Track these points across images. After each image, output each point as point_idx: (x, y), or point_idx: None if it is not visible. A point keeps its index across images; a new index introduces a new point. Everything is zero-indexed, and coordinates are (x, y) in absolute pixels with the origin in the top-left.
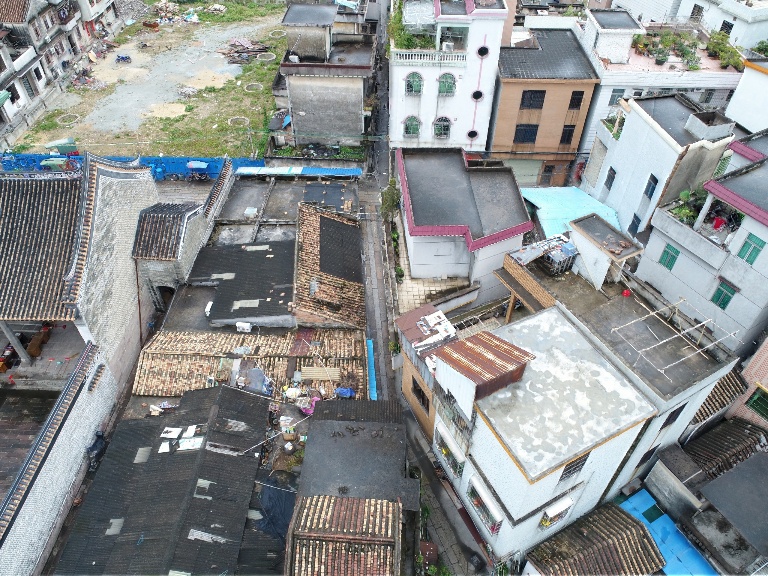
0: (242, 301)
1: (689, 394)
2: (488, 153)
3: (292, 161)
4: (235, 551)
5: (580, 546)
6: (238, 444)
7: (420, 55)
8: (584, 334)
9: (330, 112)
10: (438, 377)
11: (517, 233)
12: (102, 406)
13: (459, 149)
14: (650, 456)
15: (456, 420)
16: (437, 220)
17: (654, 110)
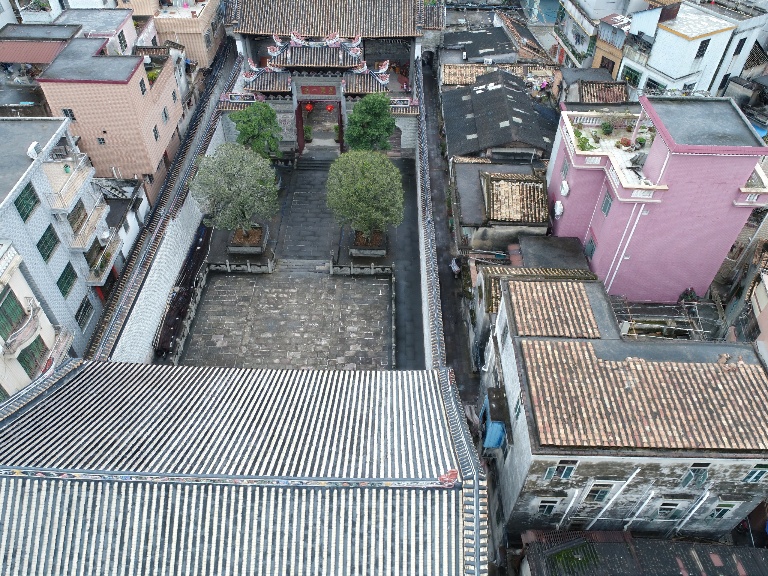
0: (484, 50)
1: (749, 26)
2: None
3: None
4: (535, 117)
5: None
6: None
7: None
8: (698, 9)
9: None
10: (632, 29)
11: None
12: None
13: None
14: (725, 85)
15: (642, 47)
16: None
17: None
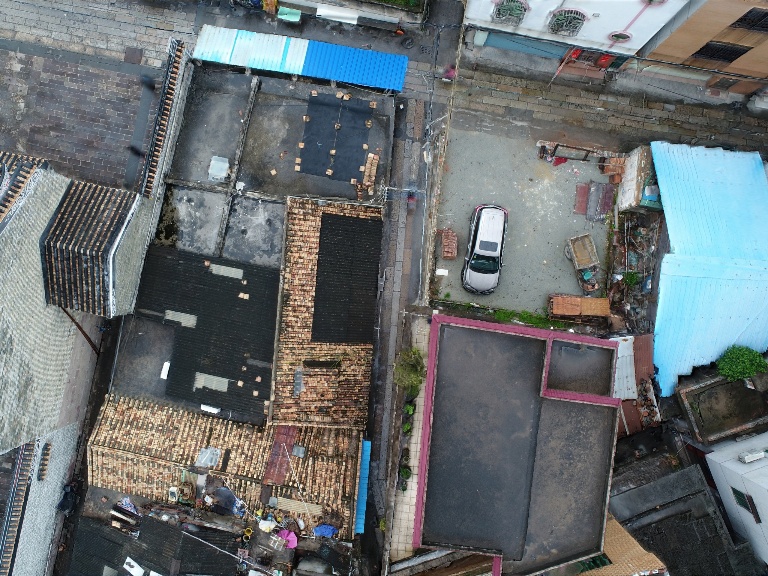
0: (206, 376)
1: None
2: (638, 59)
3: None
4: None
5: None
6: None
7: None
8: None
9: None
10: None
11: None
12: (63, 459)
13: (543, 339)
14: None
15: None
16: (461, 517)
17: None
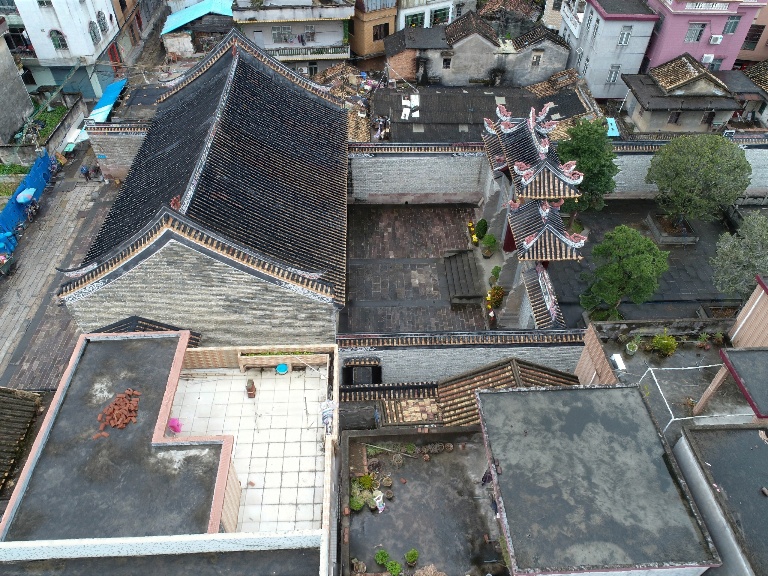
0: None
1: None
2: (121, 30)
3: (57, 134)
4: None
5: None
6: (411, 90)
7: None
8: None
9: (4, 90)
10: None
11: None
12: None
13: None
14: None
15: None
16: None
17: None
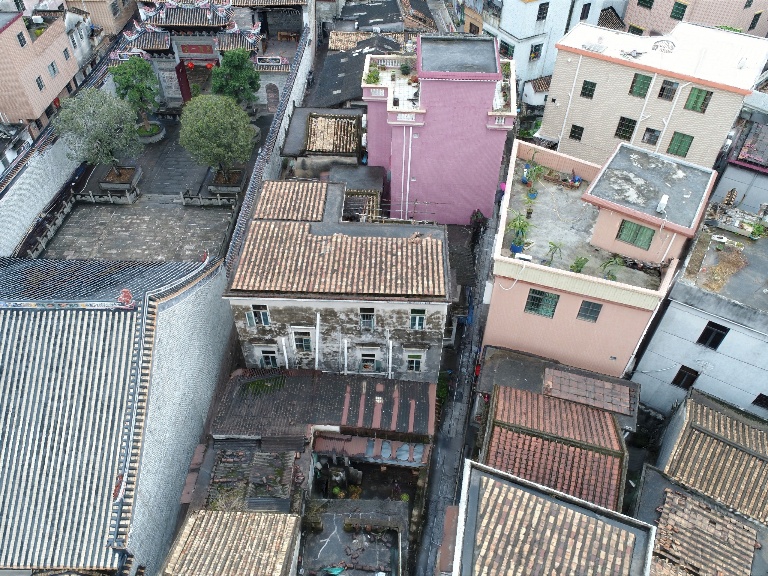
0: (374, 20)
1: None
2: None
3: None
4: None
5: None
6: None
7: None
8: None
9: None
10: None
11: None
12: (309, 63)
13: None
14: None
15: (494, 11)
16: None
17: None
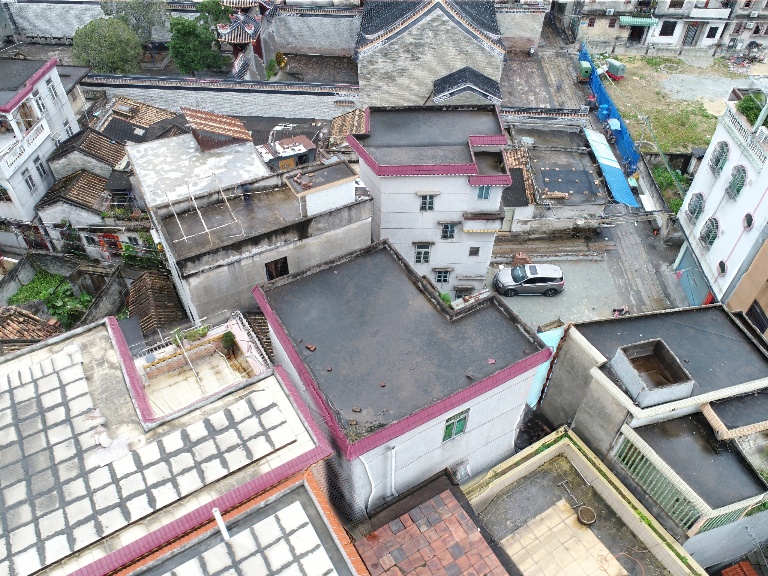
0: None
1: None
2: None
3: None
4: None
5: (158, 296)
6: None
7: (741, 126)
8: None
9: None
10: None
11: (369, 164)
12: None
13: None
14: None
15: None
16: (386, 123)
17: (701, 330)
